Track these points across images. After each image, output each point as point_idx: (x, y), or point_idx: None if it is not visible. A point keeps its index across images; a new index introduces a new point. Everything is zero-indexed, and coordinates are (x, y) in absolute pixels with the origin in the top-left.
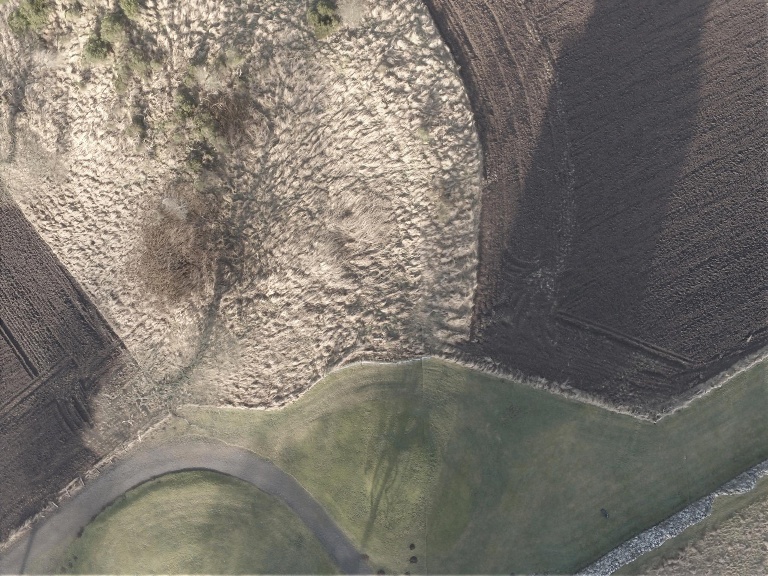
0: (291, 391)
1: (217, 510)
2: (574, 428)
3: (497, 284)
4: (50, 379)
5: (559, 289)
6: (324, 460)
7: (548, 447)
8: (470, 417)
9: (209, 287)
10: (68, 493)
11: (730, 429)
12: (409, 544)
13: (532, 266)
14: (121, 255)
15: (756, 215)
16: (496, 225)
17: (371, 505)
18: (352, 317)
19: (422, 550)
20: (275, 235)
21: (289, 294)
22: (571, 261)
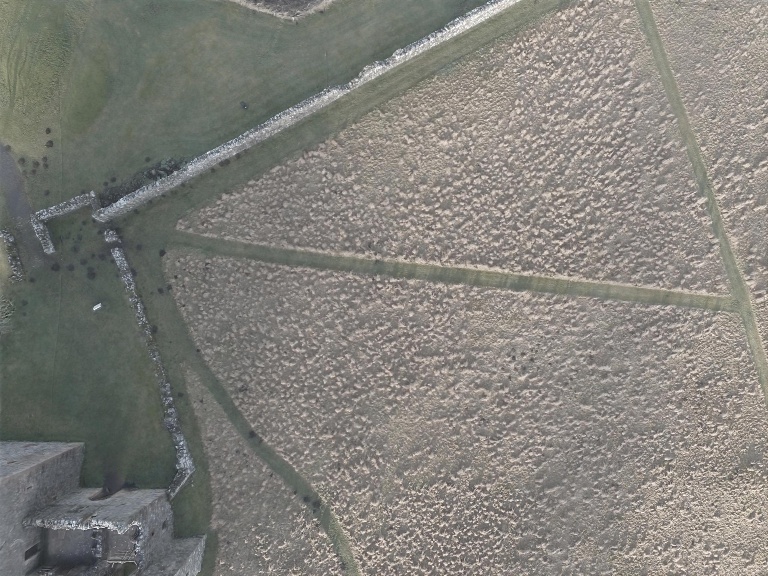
0: None
1: None
2: (215, 25)
3: None
4: None
5: None
6: None
7: (187, 42)
8: (108, 10)
9: None
10: None
11: (371, 28)
12: (45, 128)
13: None
14: None
15: None
16: None
17: (10, 94)
18: None
19: (57, 133)
20: None
21: None
22: None
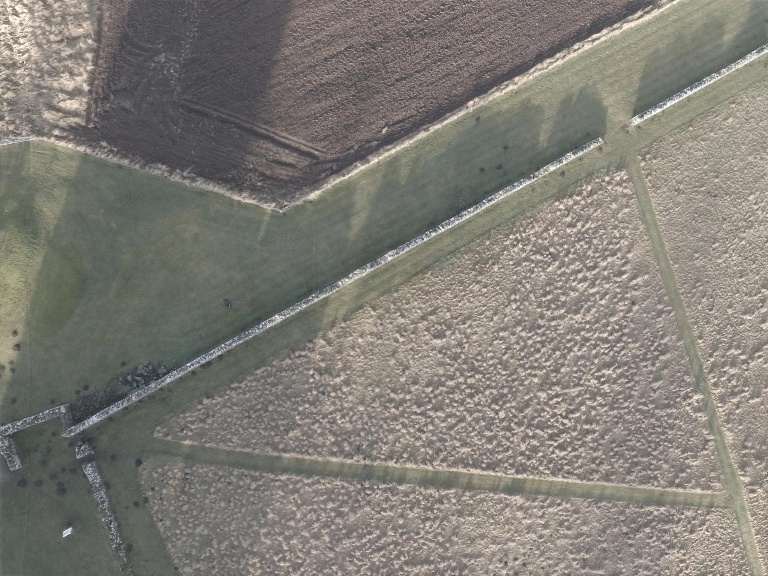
0: None
1: None
2: (197, 217)
3: (115, 67)
4: None
5: (184, 75)
6: None
7: (167, 235)
8: (81, 202)
9: None
10: None
11: (363, 220)
12: (11, 331)
13: (155, 51)
14: None
15: (395, 5)
16: (116, 7)
17: None
18: None
19: (25, 337)
20: None
21: None
22: (198, 47)
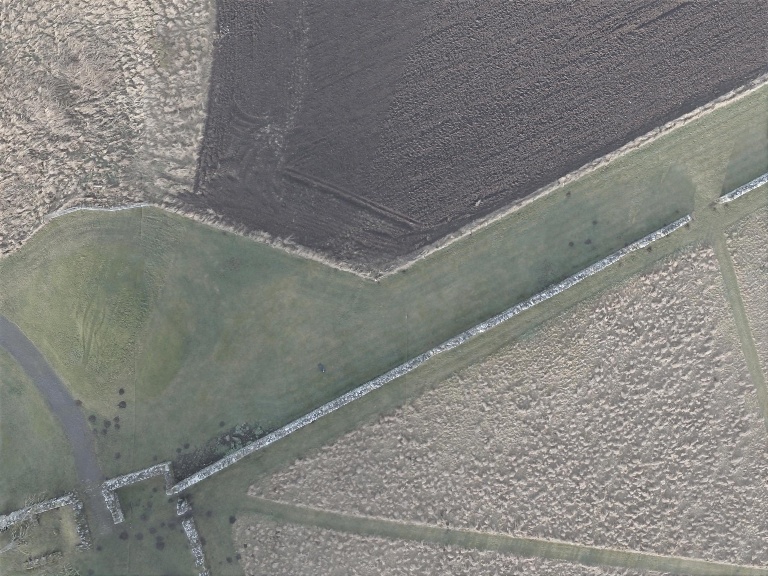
0: (15, 238)
1: None
2: (295, 283)
3: (223, 137)
4: None
5: (287, 145)
6: (43, 307)
7: (267, 300)
8: (187, 266)
9: None
10: None
11: (454, 291)
12: (118, 389)
13: (261, 122)
14: None
15: (491, 82)
16: (226, 79)
17: (84, 350)
18: (72, 163)
19: (131, 395)
20: (0, 80)
21: (15, 140)
22: (301, 119)
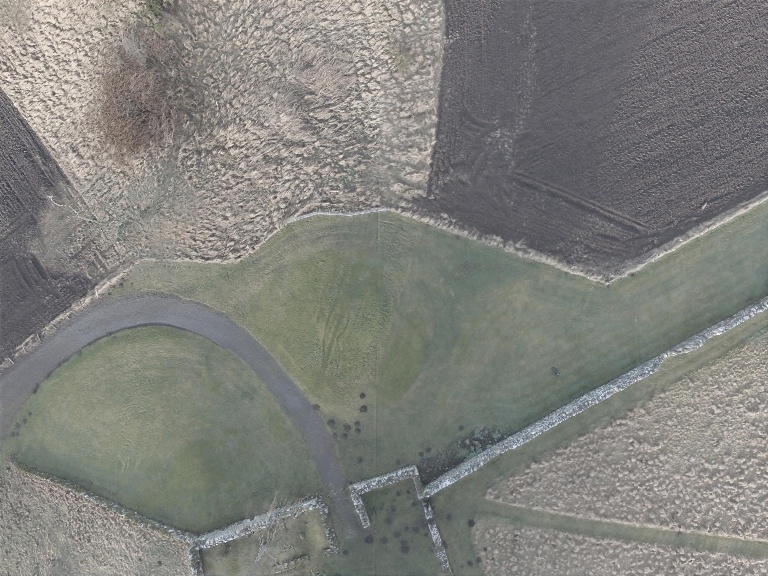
0: (247, 243)
1: (171, 363)
2: (528, 287)
3: (455, 142)
4: (9, 235)
5: (517, 150)
6: (278, 311)
7: (501, 304)
8: (424, 271)
9: (168, 136)
10: (24, 349)
11: (682, 294)
12: (359, 393)
13: (491, 126)
14: (81, 106)
15: (715, 85)
16: (456, 84)
17: (323, 354)
18: (309, 168)
19: (372, 399)
20: (235, 85)
21: (248, 146)
22: (530, 123)
